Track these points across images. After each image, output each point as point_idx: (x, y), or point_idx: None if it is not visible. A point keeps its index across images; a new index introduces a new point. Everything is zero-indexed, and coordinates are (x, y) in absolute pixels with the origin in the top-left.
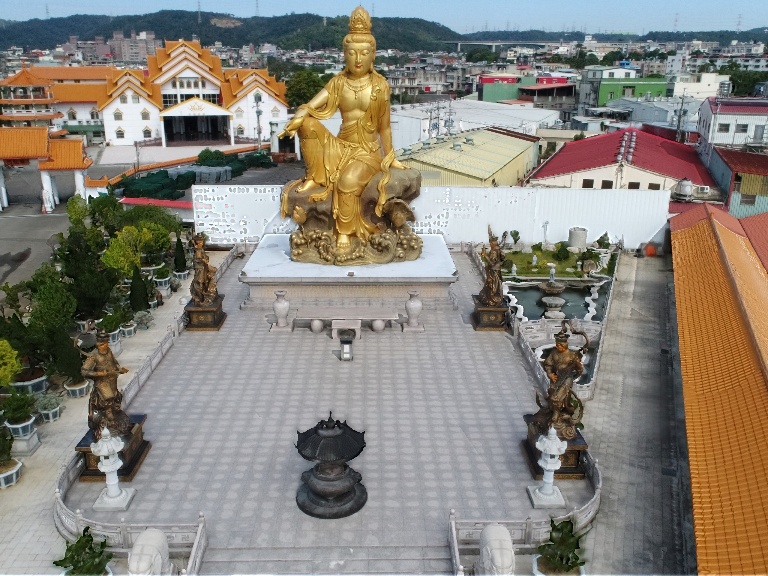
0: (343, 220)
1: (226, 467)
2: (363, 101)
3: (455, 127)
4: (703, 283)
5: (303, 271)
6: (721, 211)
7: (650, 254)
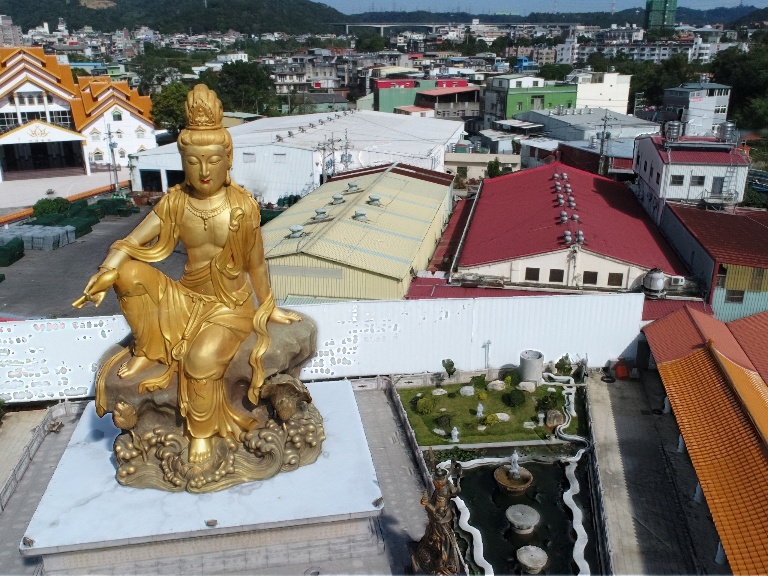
0: (197, 418)
1: None
2: (217, 233)
3: (353, 162)
4: (767, 537)
5: (133, 517)
6: (705, 316)
7: (622, 377)
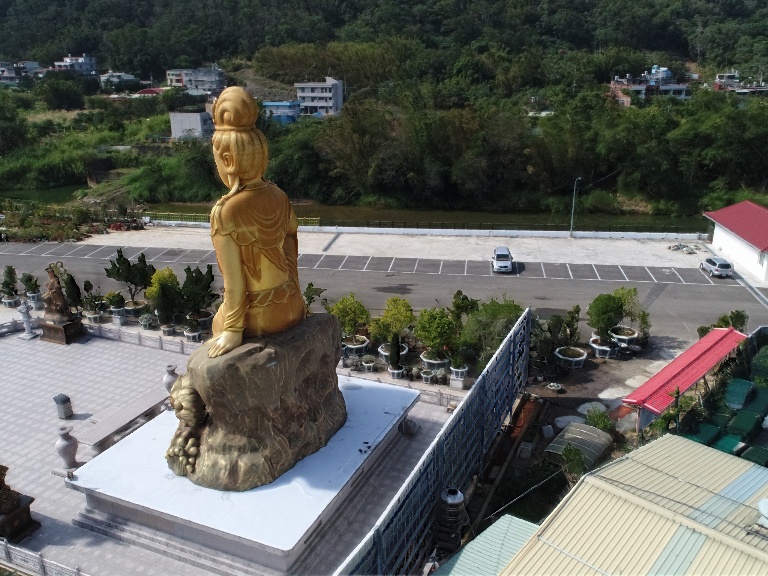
0: None
1: (8, 359)
2: None
3: None
4: None
5: None
6: None
7: None
